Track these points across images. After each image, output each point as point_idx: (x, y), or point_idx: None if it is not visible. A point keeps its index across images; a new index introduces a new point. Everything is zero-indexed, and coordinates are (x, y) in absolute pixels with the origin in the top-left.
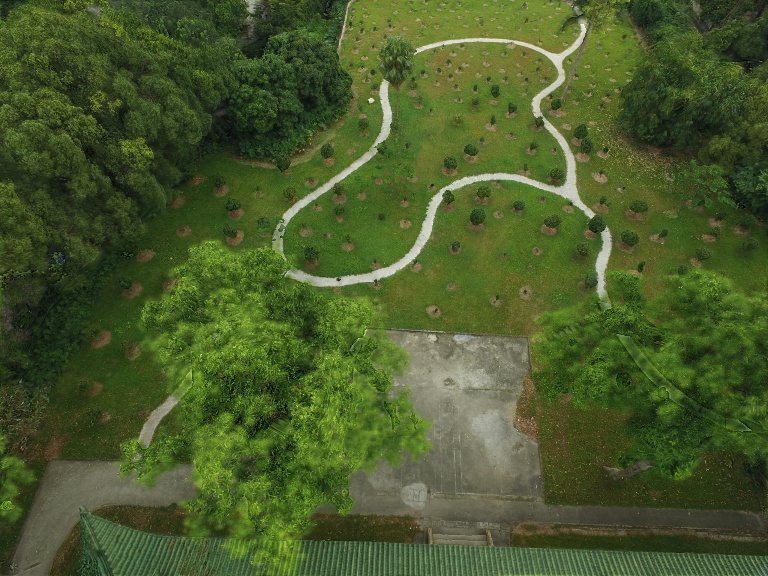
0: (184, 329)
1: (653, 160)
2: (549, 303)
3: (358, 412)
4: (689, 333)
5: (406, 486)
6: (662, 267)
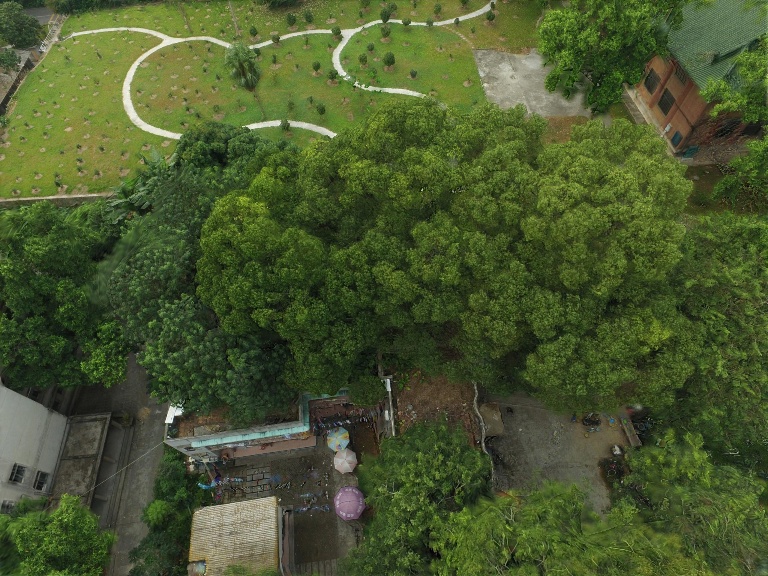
0: (637, 4)
1: (311, 1)
2: (445, 41)
3: (548, 110)
4: (449, 1)
5: (579, 89)
6: (406, 4)
